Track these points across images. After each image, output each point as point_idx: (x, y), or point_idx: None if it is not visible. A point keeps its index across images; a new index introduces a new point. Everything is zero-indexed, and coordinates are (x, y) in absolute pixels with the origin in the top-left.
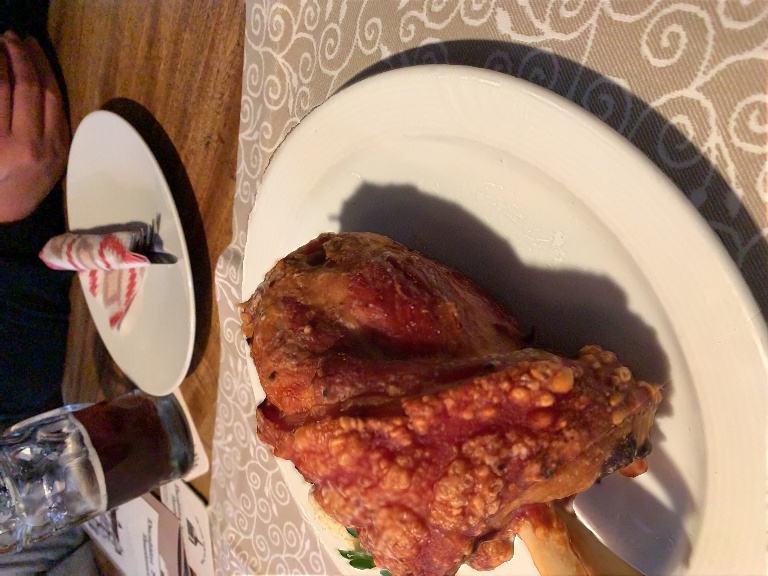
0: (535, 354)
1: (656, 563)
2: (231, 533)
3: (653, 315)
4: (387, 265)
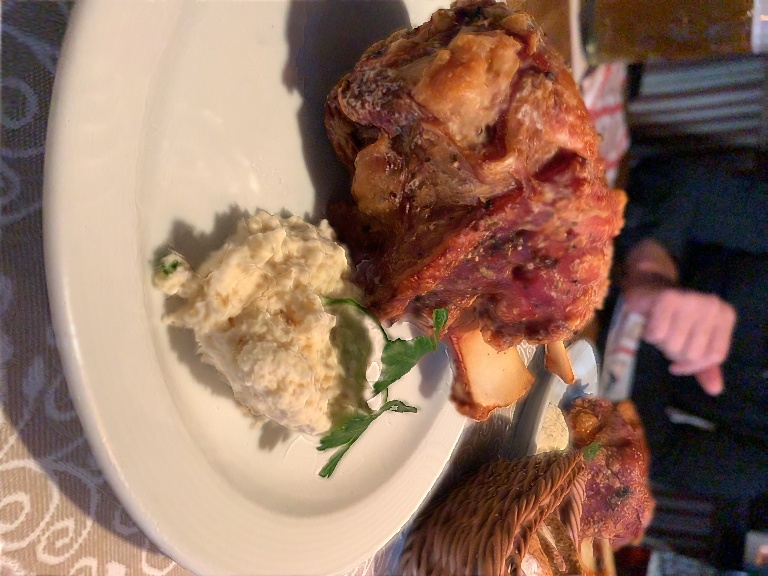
0: None
1: (444, 360)
2: None
3: None
4: None
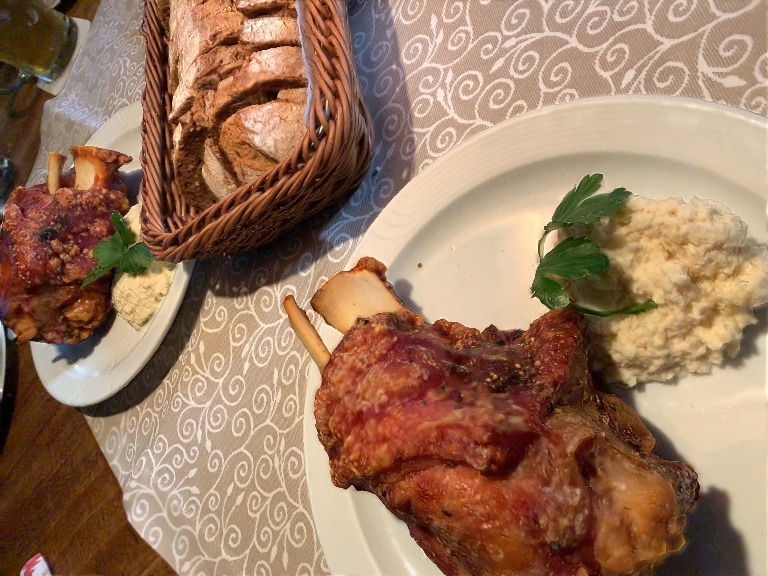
0: None
1: None
2: None
3: None
4: None
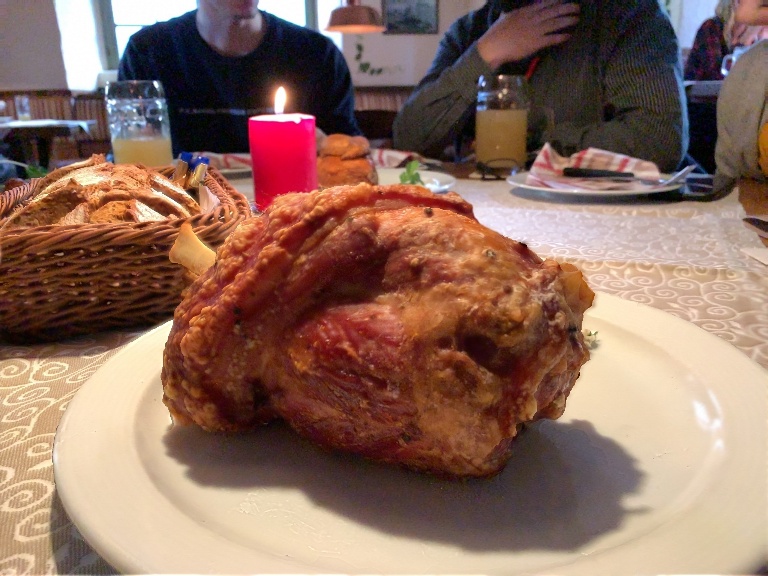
0: (229, 369)
1: None
2: (735, 277)
3: (160, 458)
4: (378, 372)
